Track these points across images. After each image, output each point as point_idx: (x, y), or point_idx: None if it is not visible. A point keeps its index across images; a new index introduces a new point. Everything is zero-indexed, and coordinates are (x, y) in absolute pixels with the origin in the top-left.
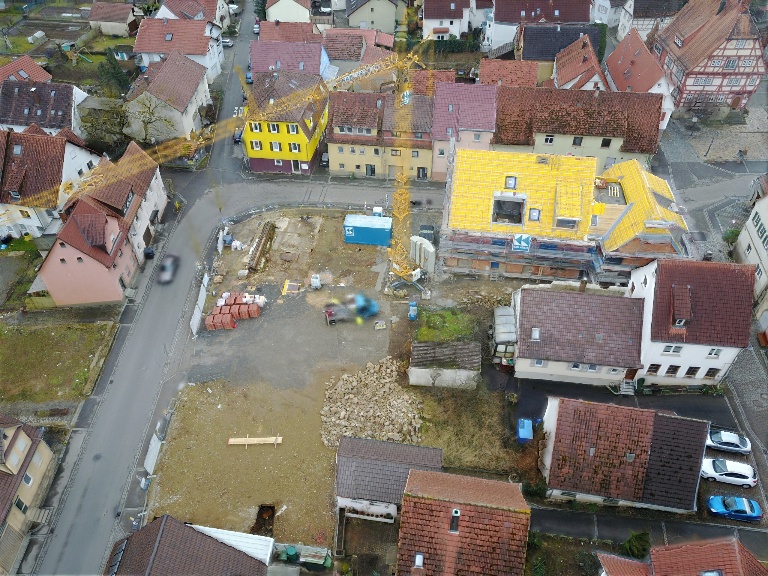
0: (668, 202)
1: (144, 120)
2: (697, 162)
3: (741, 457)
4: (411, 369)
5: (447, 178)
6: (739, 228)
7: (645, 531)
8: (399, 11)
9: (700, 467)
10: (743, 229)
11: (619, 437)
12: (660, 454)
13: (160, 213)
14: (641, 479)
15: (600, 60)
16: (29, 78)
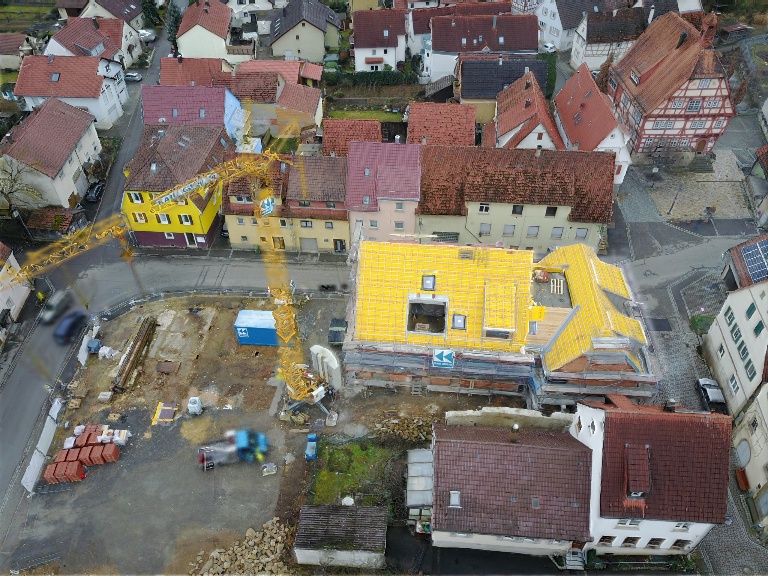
0: (622, 300)
1: (2, 190)
2: (659, 222)
3: None
4: (296, 550)
5: (350, 277)
6: (709, 312)
7: None
8: (330, 36)
9: None
10: (714, 323)
11: None
12: None
13: (17, 308)
14: None
15: (550, 94)
16: None
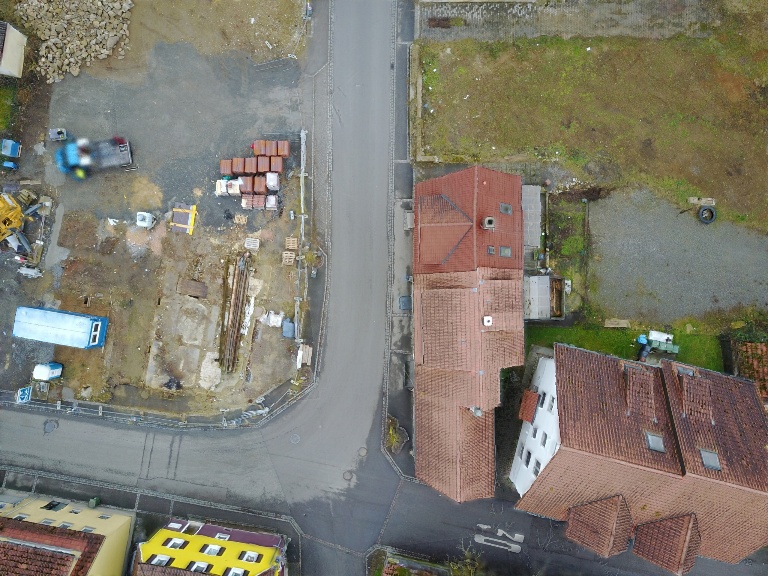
0: None
1: None
2: None
3: None
4: (7, 23)
5: None
6: None
7: None
8: None
9: None
10: None
11: None
12: None
13: None
14: None
15: None
16: None
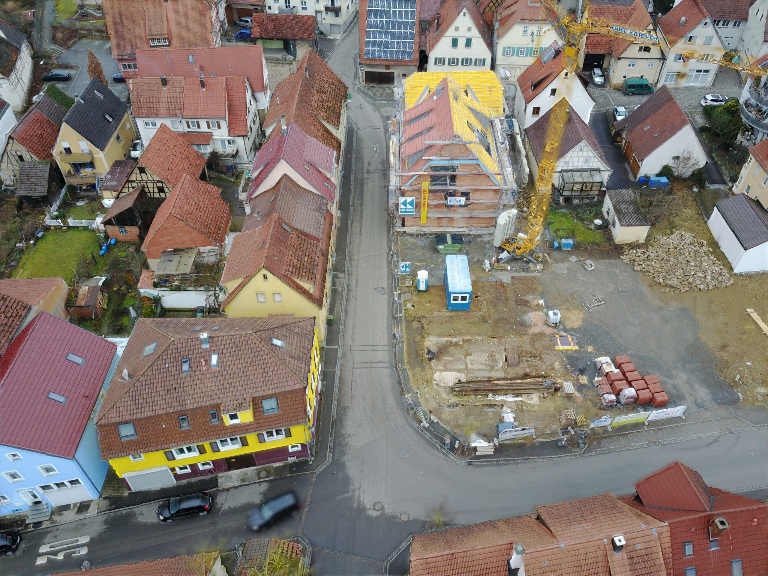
0: None
1: None
2: None
3: None
4: None
5: (475, 158)
6: None
7: None
8: None
9: None
10: None
11: None
12: None
13: None
14: None
15: None
16: None
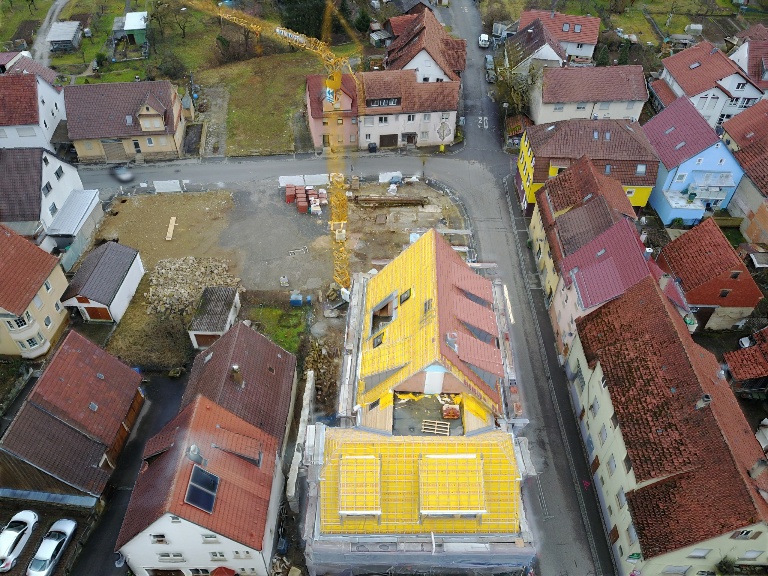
0: None
1: None
2: None
3: None
4: None
5: (407, 245)
6: None
7: None
8: None
9: None
10: None
11: None
12: None
13: (427, 142)
14: None
15: None
16: (541, 23)
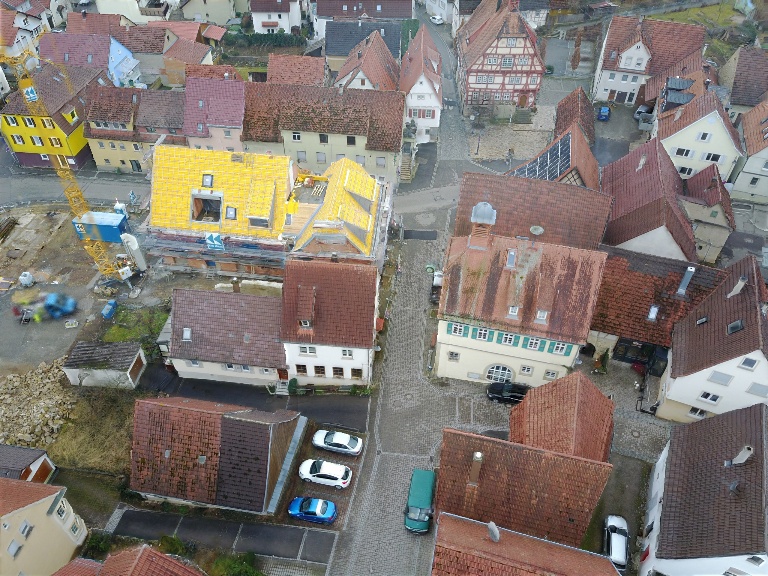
0: (367, 201)
1: None
2: (465, 160)
3: (351, 458)
4: (63, 369)
5: None
6: None
7: (220, 533)
8: (241, 3)
9: (266, 469)
10: None
11: (191, 439)
12: (229, 456)
13: None
14: (213, 481)
15: None
16: None
